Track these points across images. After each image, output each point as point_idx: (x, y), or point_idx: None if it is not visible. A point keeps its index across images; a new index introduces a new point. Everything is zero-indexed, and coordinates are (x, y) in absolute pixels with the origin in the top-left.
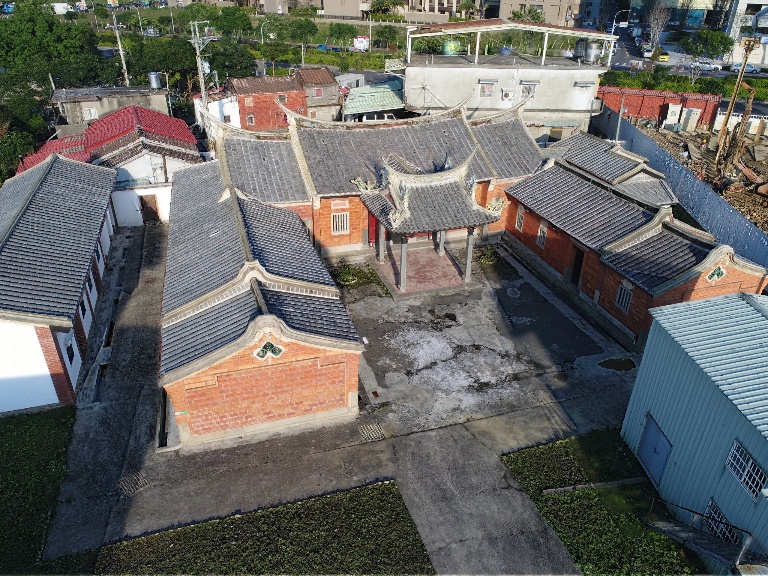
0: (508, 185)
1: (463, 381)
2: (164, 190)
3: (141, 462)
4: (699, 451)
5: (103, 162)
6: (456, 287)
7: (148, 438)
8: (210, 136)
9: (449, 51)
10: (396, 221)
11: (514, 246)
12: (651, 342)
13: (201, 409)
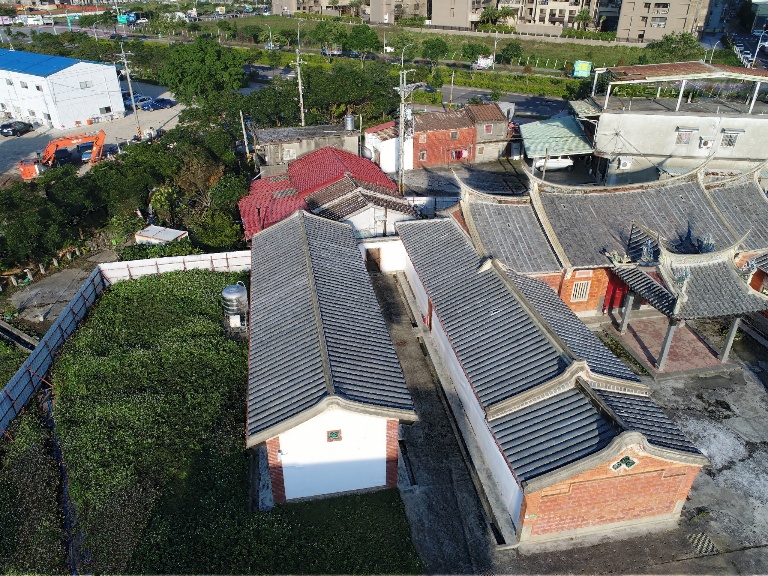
0: (752, 256)
1: None
2: (390, 244)
3: (487, 560)
4: None
5: (323, 211)
6: (714, 368)
7: (482, 532)
8: (402, 179)
9: (637, 93)
10: None
11: (754, 319)
12: None
13: (547, 513)
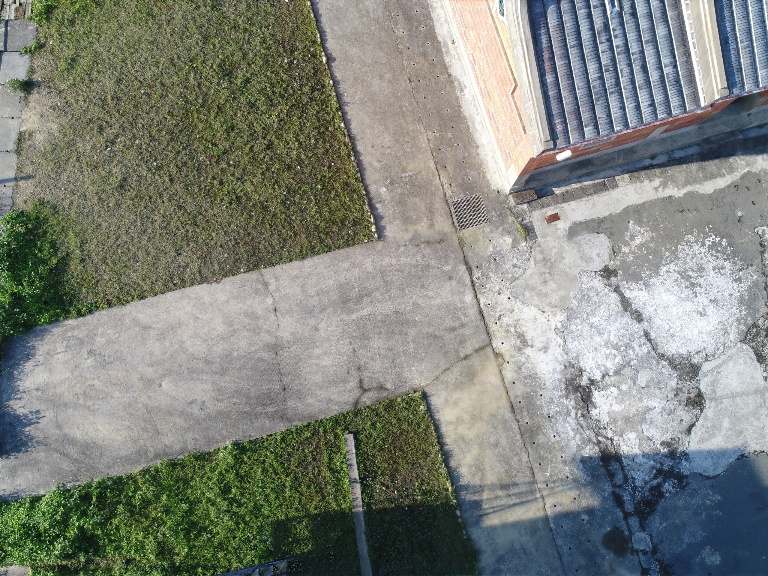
0: None
1: (592, 361)
2: None
3: None
4: None
5: None
6: None
7: None
8: None
9: None
10: None
11: None
12: None
13: None
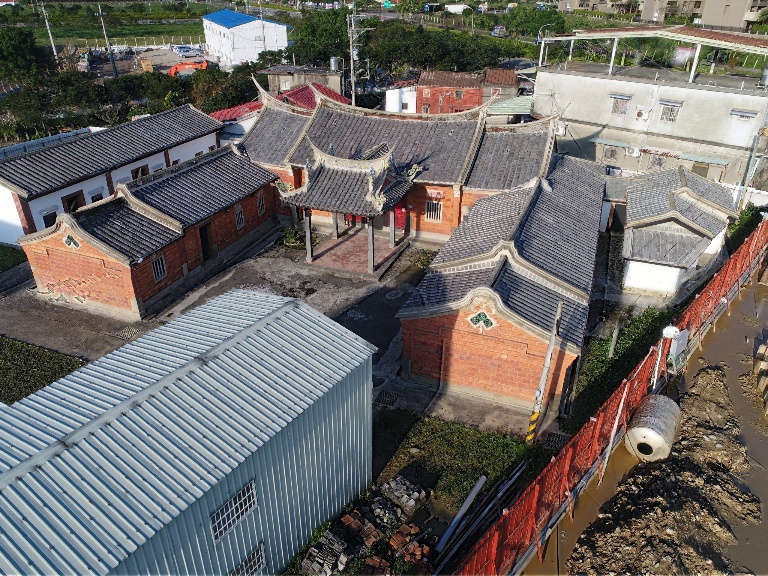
0: (482, 196)
1: None
2: None
3: (15, 292)
4: None
5: None
6: (353, 273)
7: None
8: None
9: None
10: (288, 192)
11: None
12: None
13: (44, 270)
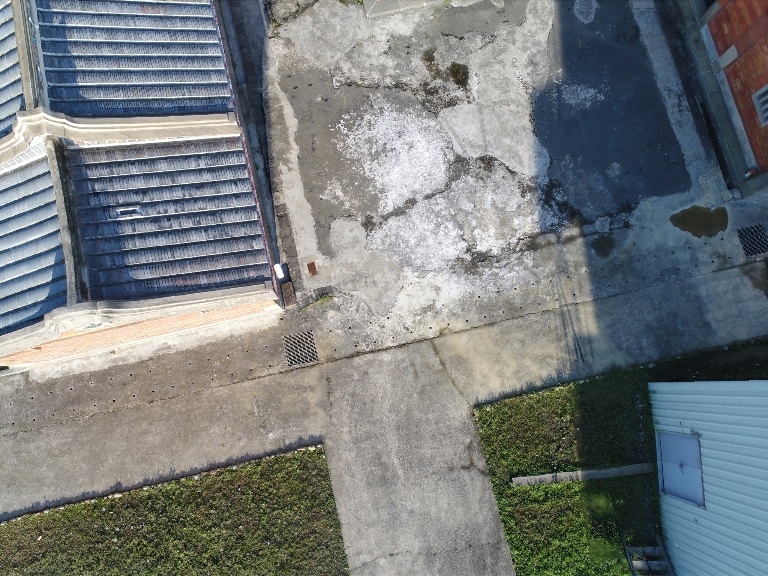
0: None
1: (450, 248)
2: None
3: None
4: (735, 574)
5: None
6: None
7: None
8: None
9: None
10: None
11: None
12: (761, 395)
13: (32, 356)
